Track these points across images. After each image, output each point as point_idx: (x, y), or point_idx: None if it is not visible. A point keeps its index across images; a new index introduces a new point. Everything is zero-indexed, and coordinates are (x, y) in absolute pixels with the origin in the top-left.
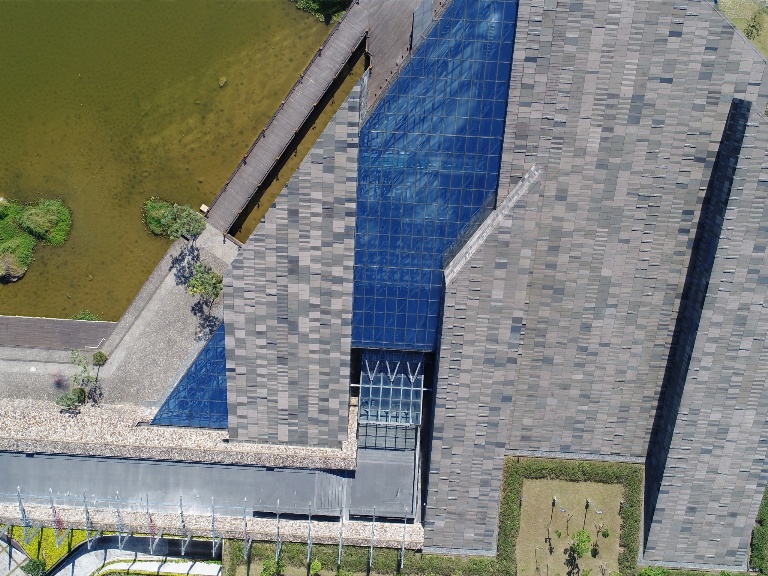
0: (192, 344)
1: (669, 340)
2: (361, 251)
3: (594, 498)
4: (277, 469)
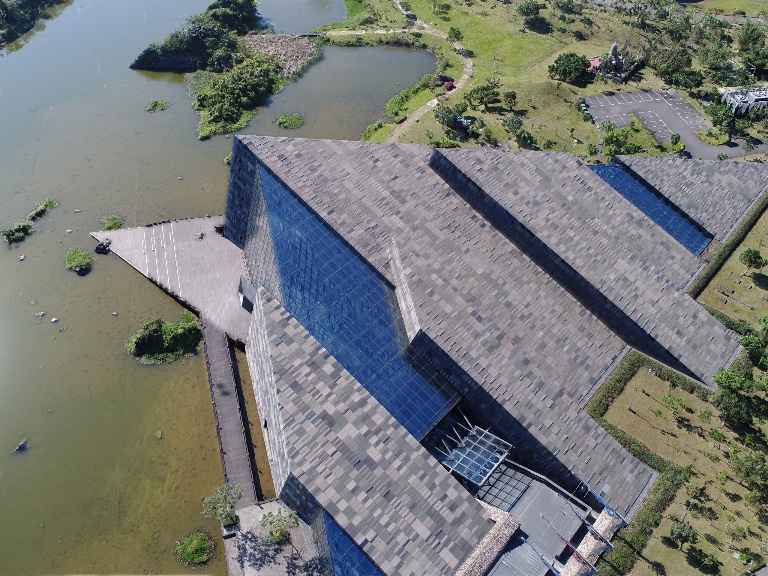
0: None
1: (547, 276)
2: (356, 376)
3: None
4: None
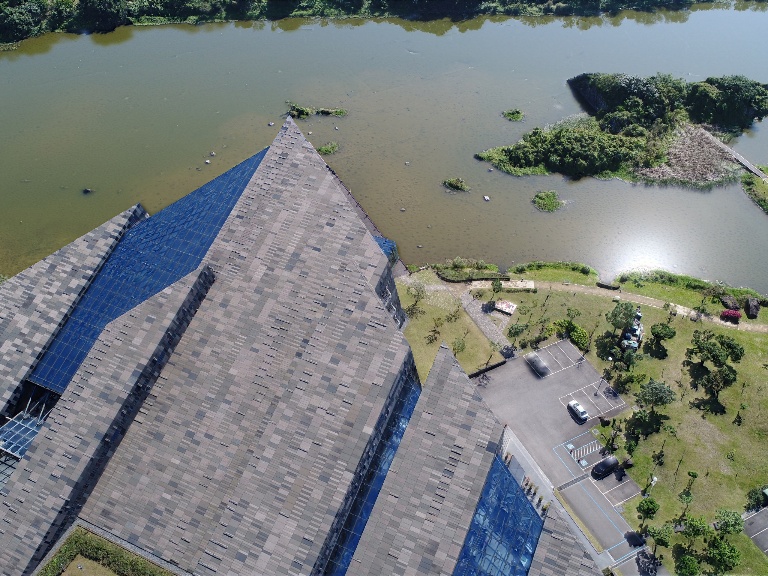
0: None
1: None
2: (79, 308)
3: None
4: None
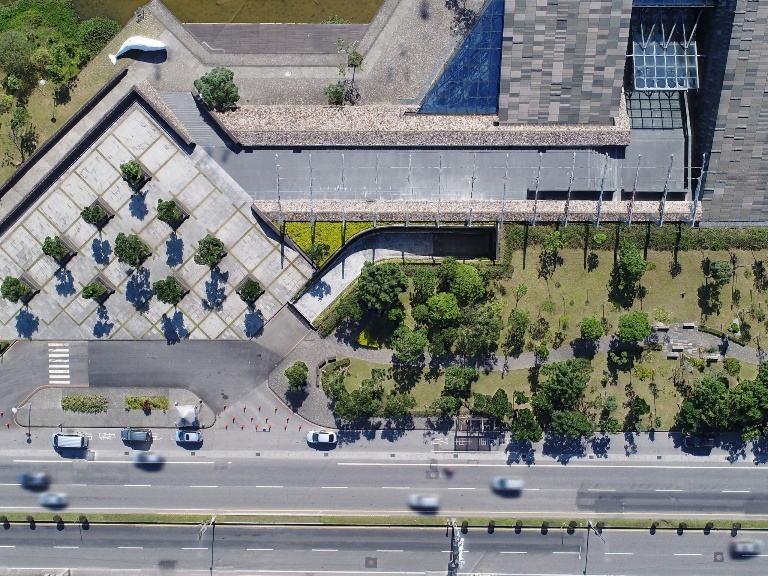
0: (448, 39)
1: None
2: None
3: None
4: (548, 150)
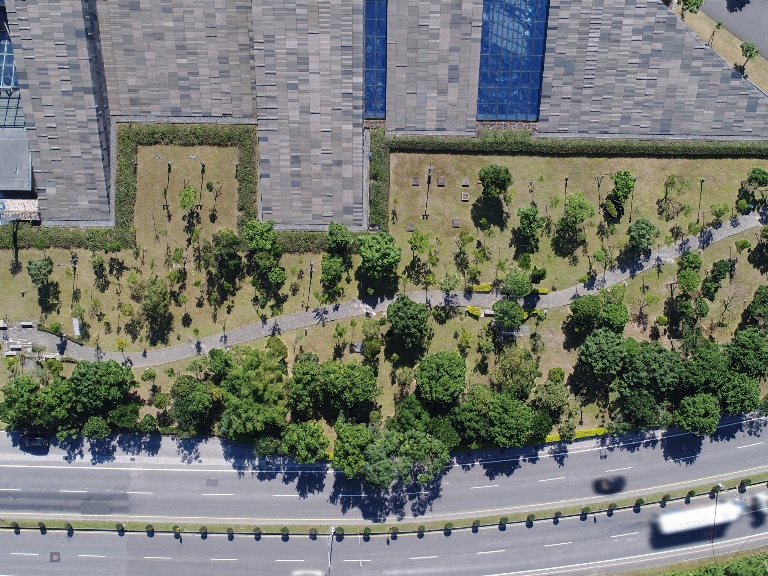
0: None
1: None
2: None
3: (210, 162)
4: None
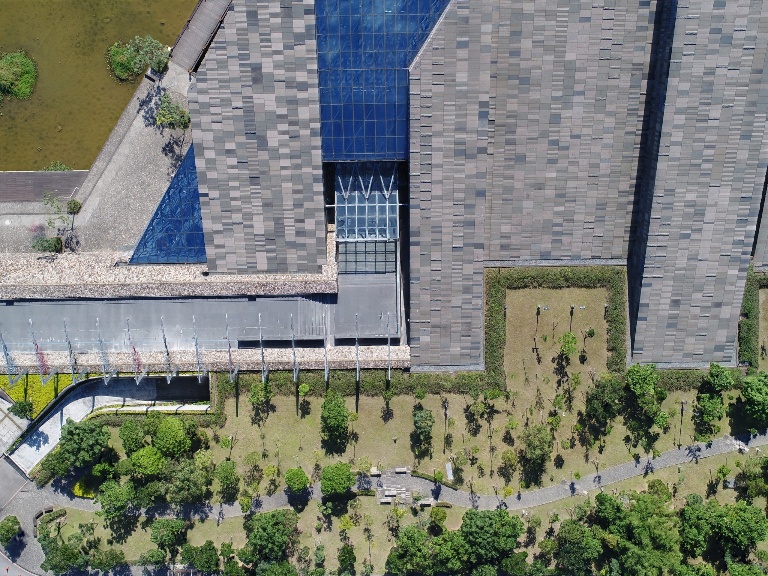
0: (165, 185)
1: (639, 126)
2: (324, 54)
3: (578, 304)
4: (259, 299)
